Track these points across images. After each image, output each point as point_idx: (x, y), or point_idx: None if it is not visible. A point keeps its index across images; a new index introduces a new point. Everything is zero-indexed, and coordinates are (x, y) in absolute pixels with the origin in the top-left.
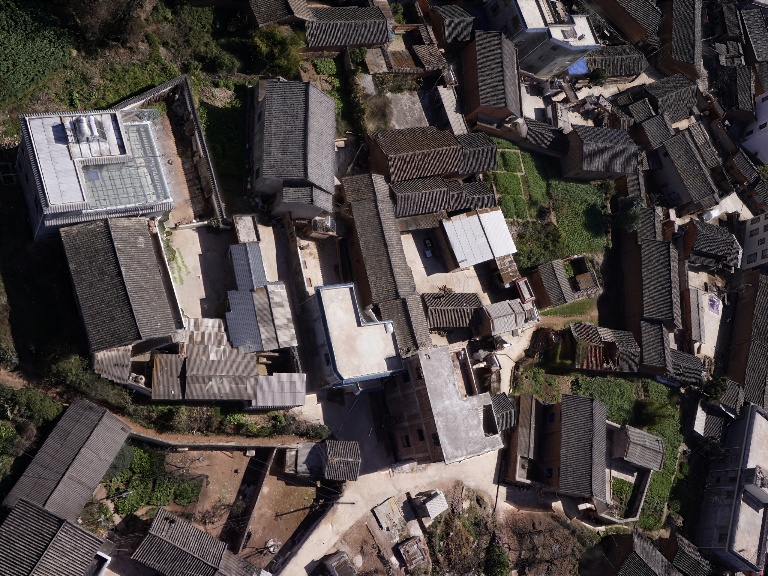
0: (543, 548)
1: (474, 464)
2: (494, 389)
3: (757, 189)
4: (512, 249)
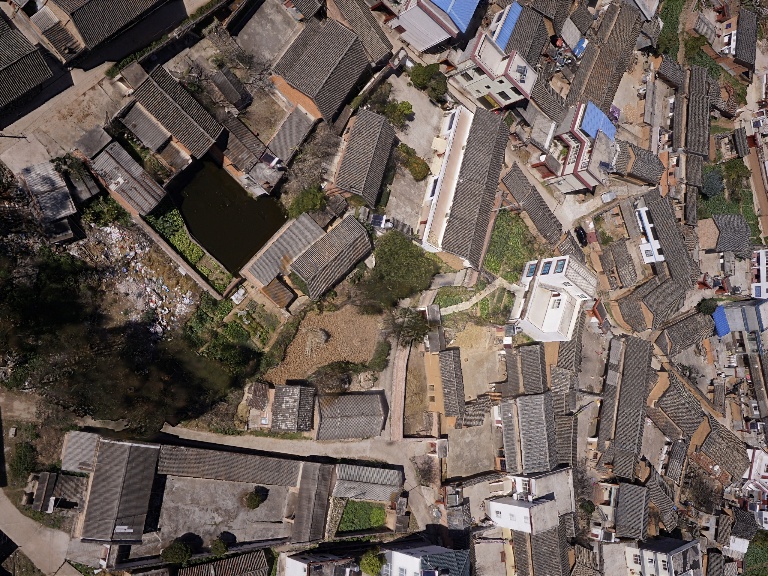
0: (731, 5)
1: (758, 59)
2: (767, 89)
3: (560, 224)
4: (767, 163)
